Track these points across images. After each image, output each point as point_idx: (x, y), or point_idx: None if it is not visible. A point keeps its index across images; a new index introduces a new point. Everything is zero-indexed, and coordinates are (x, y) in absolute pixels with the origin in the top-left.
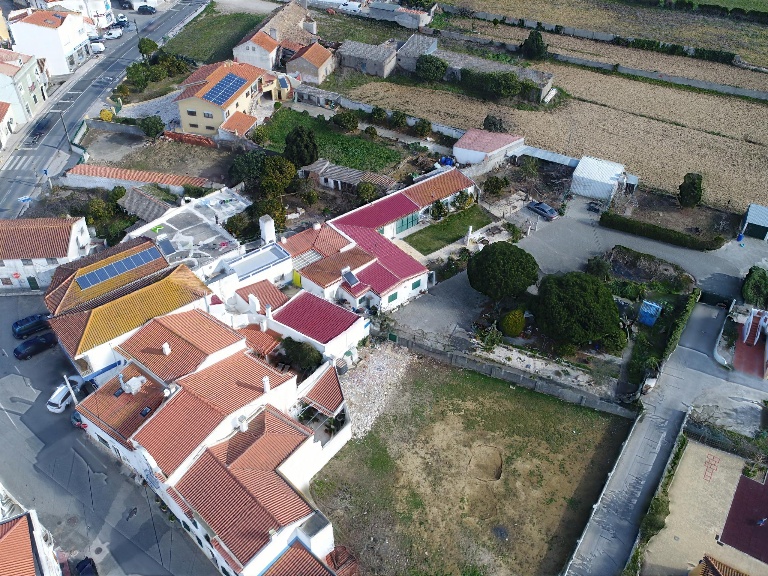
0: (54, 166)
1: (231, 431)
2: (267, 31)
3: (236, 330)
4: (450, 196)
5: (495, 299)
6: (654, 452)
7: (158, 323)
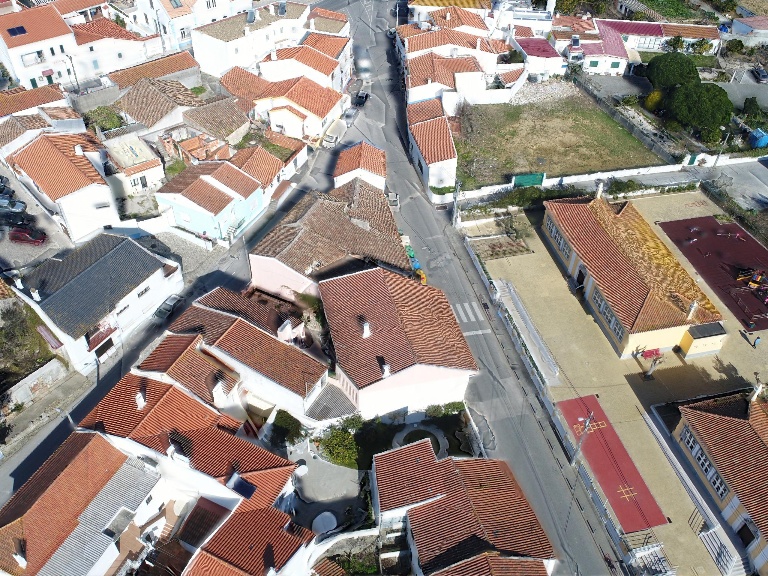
0: None
1: (449, 55)
2: None
3: (494, 39)
4: (694, 39)
5: (655, 87)
6: (668, 182)
7: (454, 8)
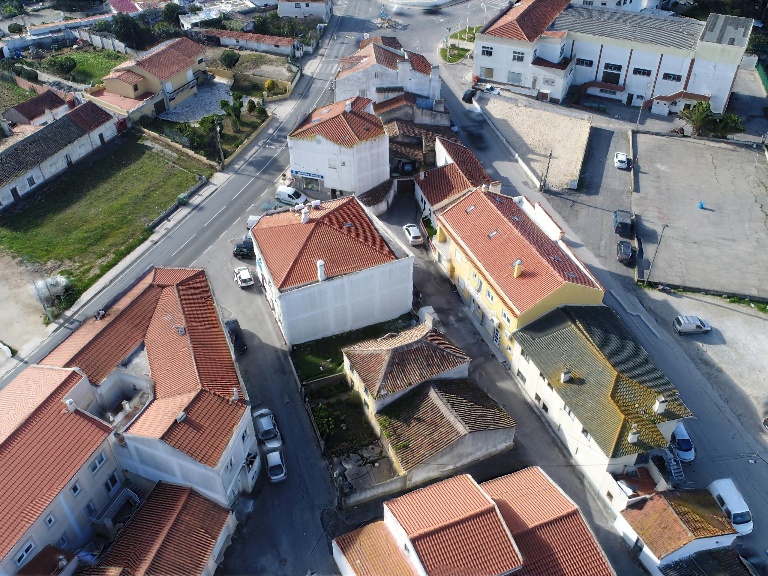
0: (314, 66)
1: None
2: None
3: None
4: None
5: None
6: None
7: None
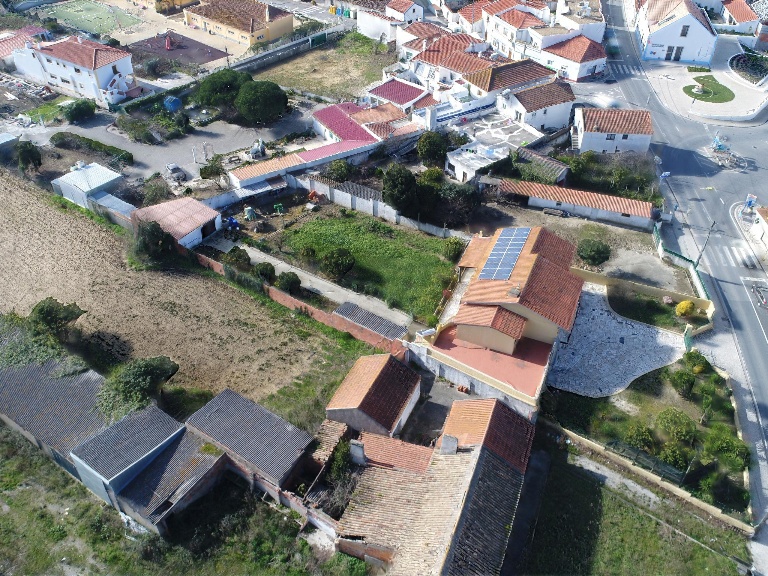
0: (693, 250)
1: None
2: (467, 460)
3: None
4: None
5: None
6: None
7: None
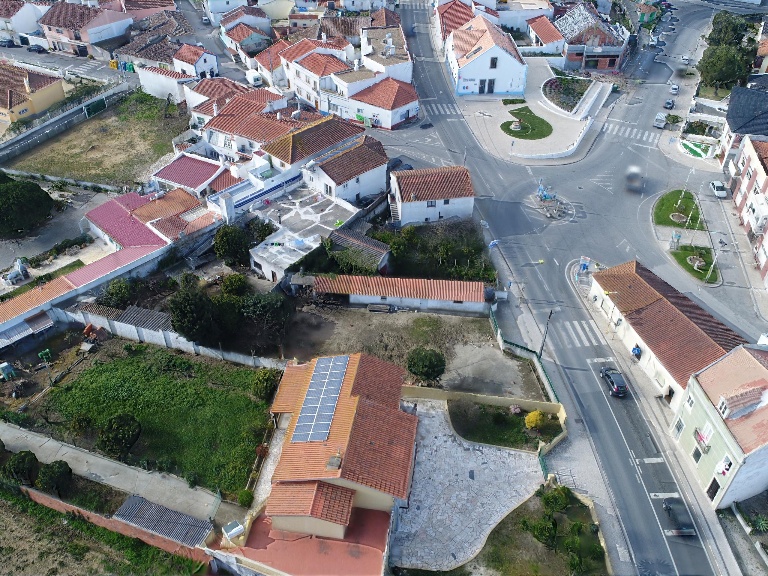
0: (535, 332)
1: None
2: None
3: None
4: None
5: None
6: None
7: None
